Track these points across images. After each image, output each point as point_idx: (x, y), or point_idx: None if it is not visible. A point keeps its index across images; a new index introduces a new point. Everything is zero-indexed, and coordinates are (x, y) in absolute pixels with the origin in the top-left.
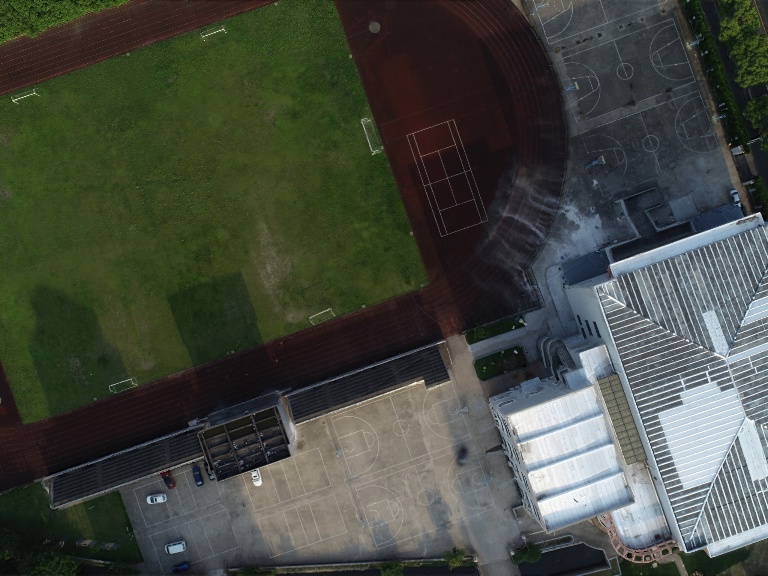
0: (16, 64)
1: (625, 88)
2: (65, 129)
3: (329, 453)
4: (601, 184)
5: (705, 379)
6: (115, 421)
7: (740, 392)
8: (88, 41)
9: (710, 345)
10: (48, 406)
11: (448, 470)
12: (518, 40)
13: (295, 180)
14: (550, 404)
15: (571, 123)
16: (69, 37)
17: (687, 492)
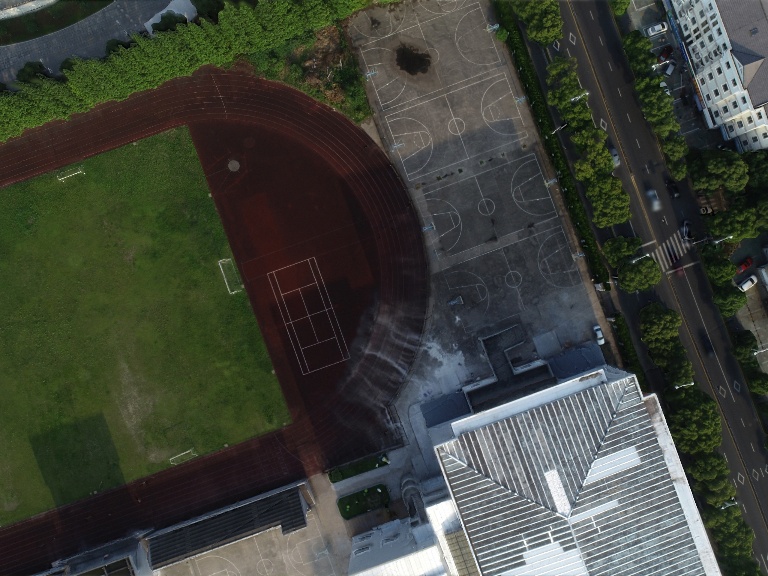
0: None
1: (487, 224)
2: None
3: None
4: (464, 320)
5: (547, 539)
6: None
7: (583, 552)
8: None
9: (552, 505)
10: None
11: None
12: (378, 177)
13: (156, 320)
14: (394, 563)
15: (432, 259)
16: None
17: None
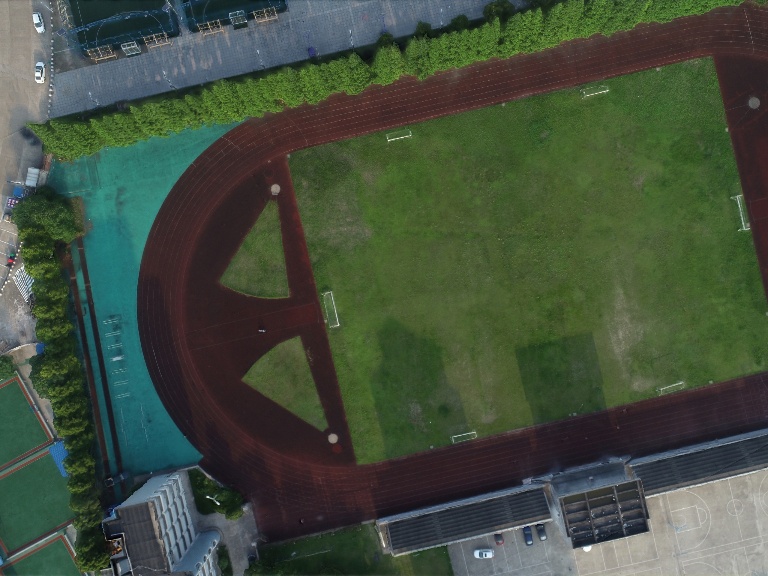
0: (390, 103)
1: None
2: (432, 173)
3: (660, 525)
4: None
5: None
6: (449, 471)
7: None
8: (465, 87)
9: None
10: (384, 449)
11: None
12: None
13: (657, 248)
14: None
15: None
16: (446, 81)
17: None
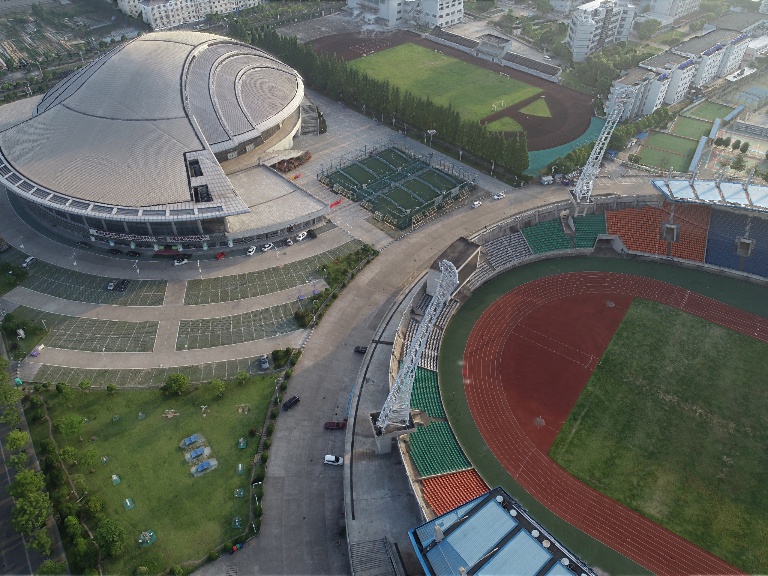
0: None
1: None
2: None
3: None
4: None
5: None
6: None
7: None
8: None
9: None
10: None
11: None
12: None
13: None
14: None
15: None
16: None
17: None
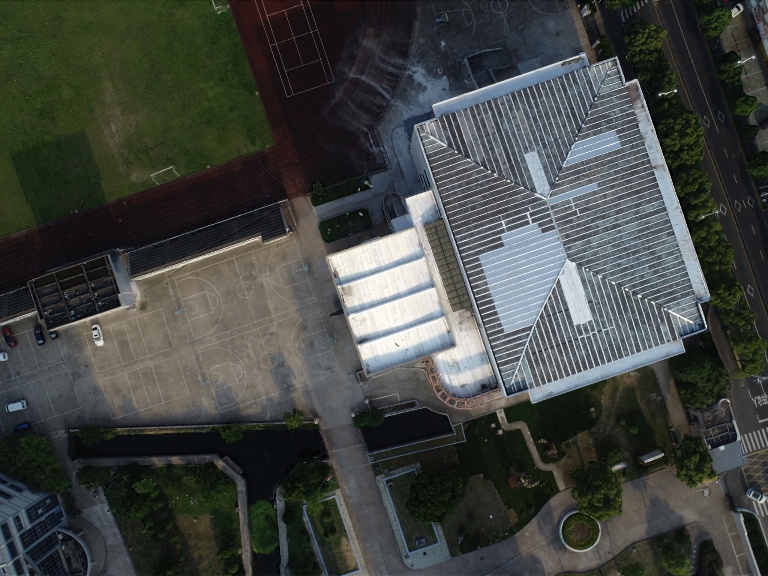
0: None
1: None
2: None
3: (172, 314)
4: (449, 45)
5: (526, 220)
6: None
7: (561, 234)
8: None
9: (531, 186)
10: None
11: (292, 333)
12: None
13: (140, 38)
14: (372, 246)
15: None
16: None
17: (508, 336)
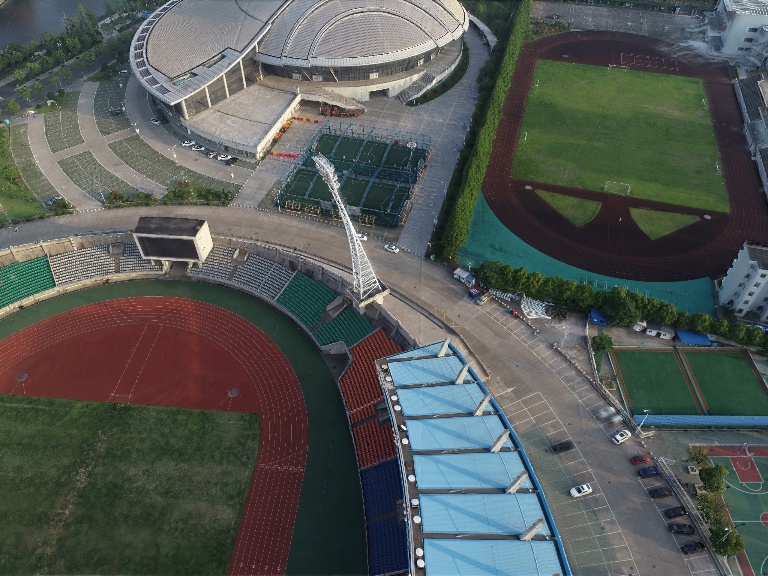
0: None
1: None
2: None
3: None
4: None
5: None
6: None
7: None
8: (509, 116)
9: None
10: (720, 200)
11: None
12: None
13: (625, 91)
14: None
15: None
16: None
17: None
